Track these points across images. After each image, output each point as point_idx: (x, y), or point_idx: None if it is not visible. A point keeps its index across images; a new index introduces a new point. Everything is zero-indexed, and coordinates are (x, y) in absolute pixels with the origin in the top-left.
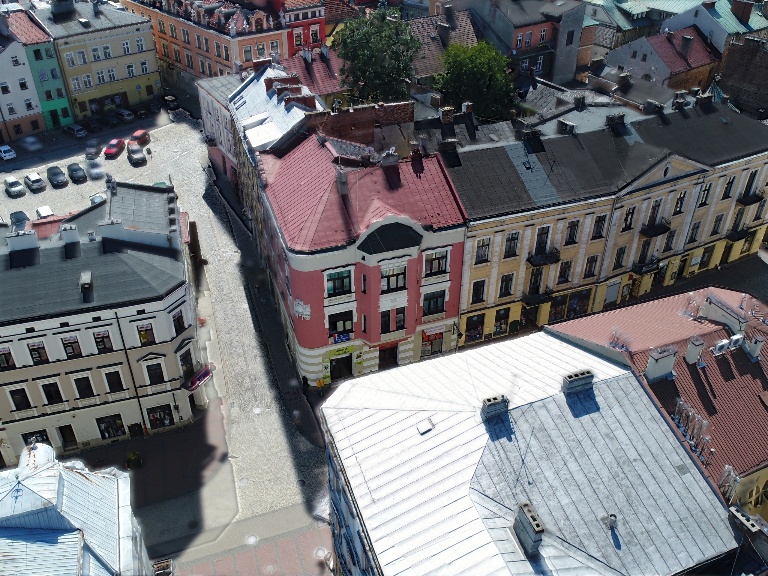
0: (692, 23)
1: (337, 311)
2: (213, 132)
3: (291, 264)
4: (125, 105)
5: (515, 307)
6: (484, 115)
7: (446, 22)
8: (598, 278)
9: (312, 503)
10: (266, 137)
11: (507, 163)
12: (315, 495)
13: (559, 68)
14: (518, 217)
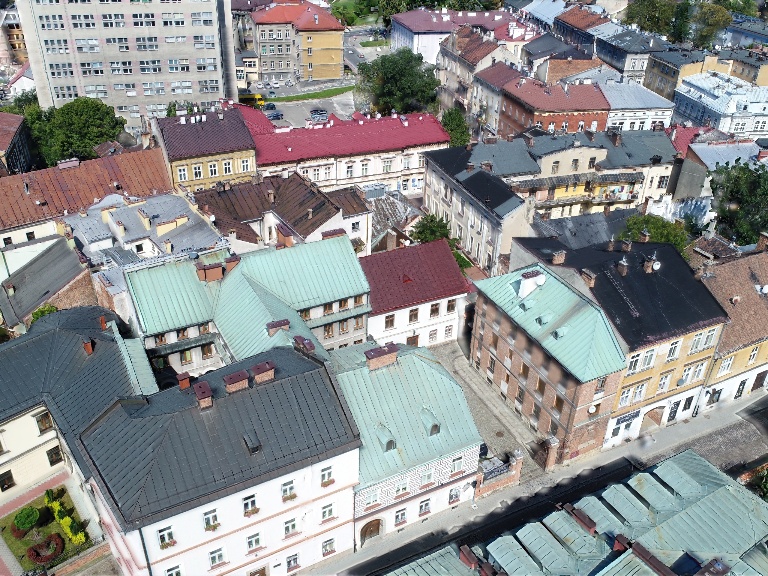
0: None
1: None
2: None
3: None
4: None
5: None
6: None
7: None
8: None
9: None
10: None
11: None
12: None
13: None
14: None
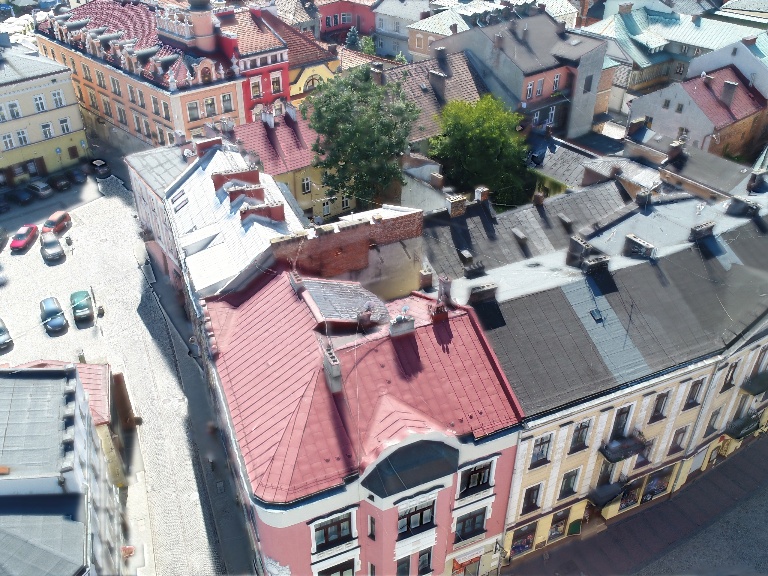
0: (729, 63)
1: (331, 564)
2: (149, 221)
3: (258, 514)
4: (42, 173)
5: (578, 505)
6: (492, 187)
7: (439, 68)
8: (685, 451)
9: None
10: (215, 272)
11: (568, 315)
12: None
13: (575, 120)
14: (593, 404)
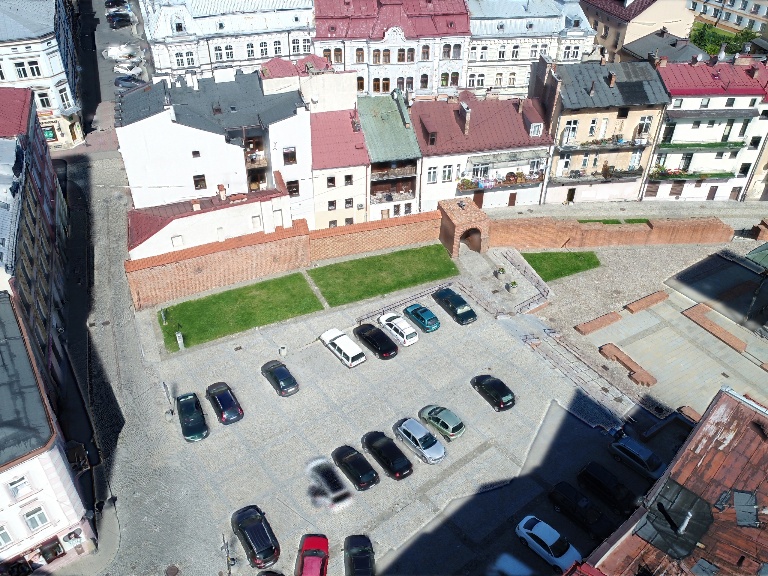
0: None
1: None
2: None
3: None
4: None
5: None
6: None
7: None
8: None
9: (87, 160)
10: None
11: None
12: (83, 163)
13: None
14: None
